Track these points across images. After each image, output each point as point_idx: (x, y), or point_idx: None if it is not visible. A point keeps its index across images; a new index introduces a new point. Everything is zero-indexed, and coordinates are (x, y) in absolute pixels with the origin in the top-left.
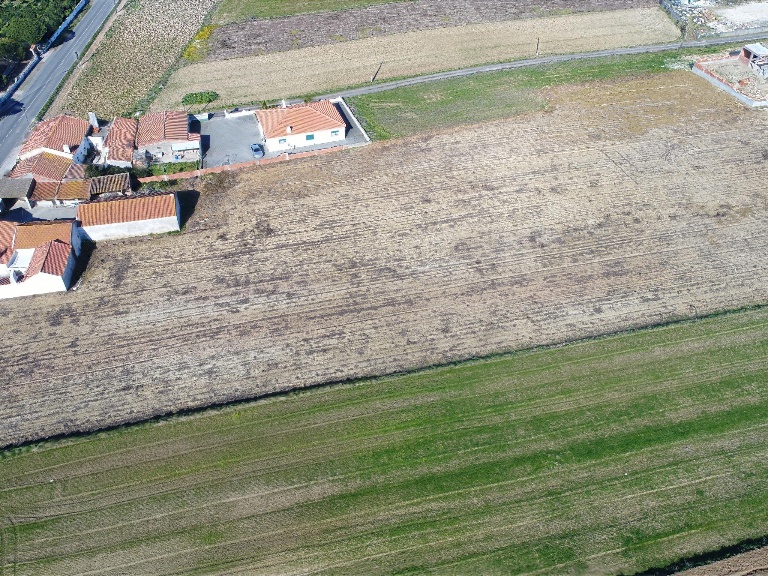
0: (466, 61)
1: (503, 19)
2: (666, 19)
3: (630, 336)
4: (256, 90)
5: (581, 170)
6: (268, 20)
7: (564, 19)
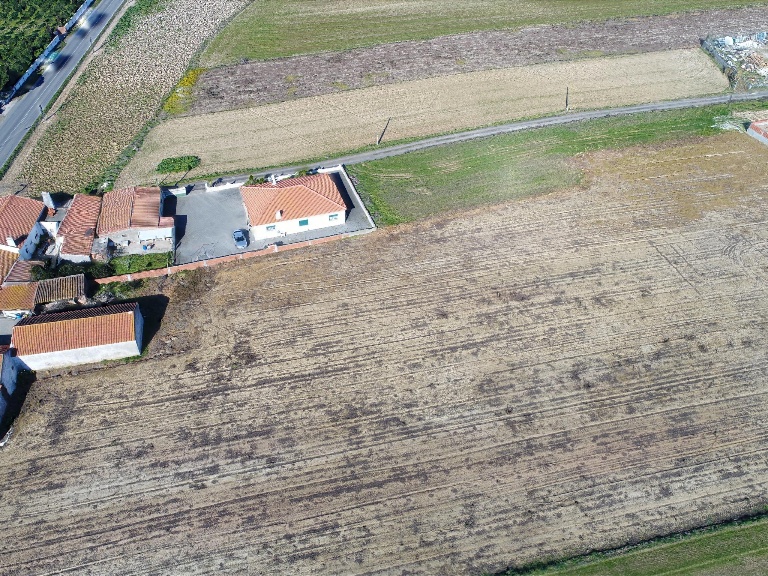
0: (486, 118)
1: (526, 63)
2: (710, 64)
3: (711, 536)
4: (244, 154)
5: (629, 271)
6: (262, 62)
7: (595, 63)
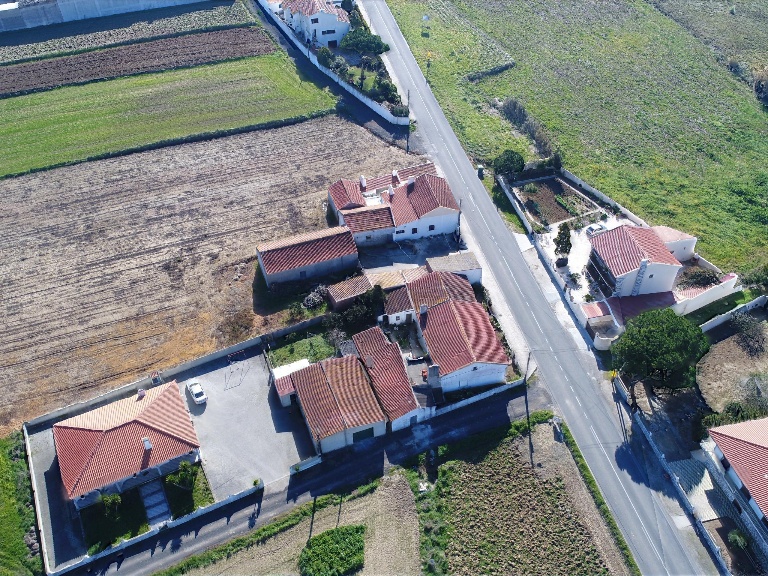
0: None
1: None
2: None
3: None
4: None
5: None
6: None
7: None
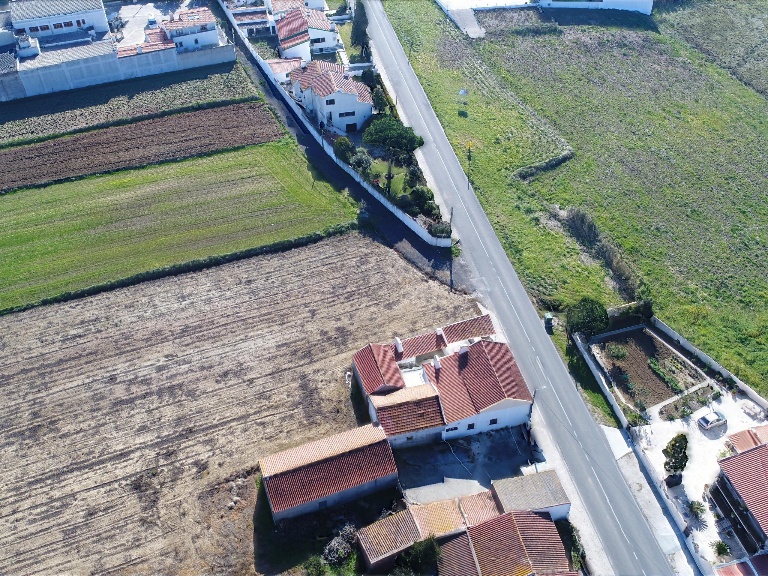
0: None
1: None
2: None
3: None
4: None
5: None
6: None
7: None
